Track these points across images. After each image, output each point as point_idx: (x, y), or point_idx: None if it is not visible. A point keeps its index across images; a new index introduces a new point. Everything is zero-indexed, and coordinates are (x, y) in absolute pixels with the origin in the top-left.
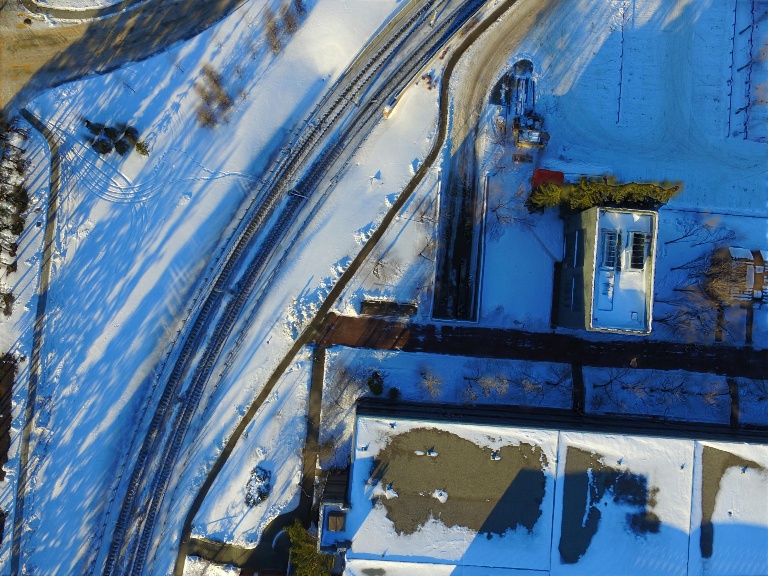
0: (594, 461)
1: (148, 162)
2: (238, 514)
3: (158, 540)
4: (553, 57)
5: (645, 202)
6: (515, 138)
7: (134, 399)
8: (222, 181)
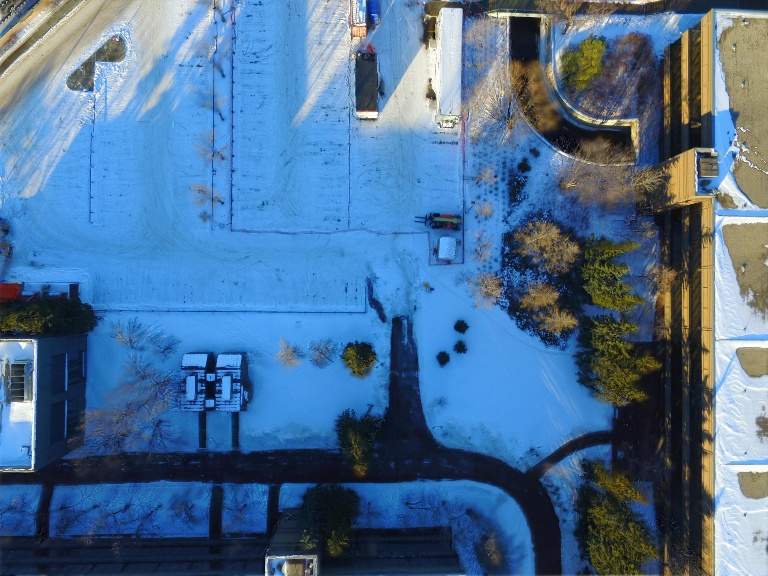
0: None
1: None
2: None
3: None
4: (18, 157)
5: (18, 331)
6: None
7: None
8: None
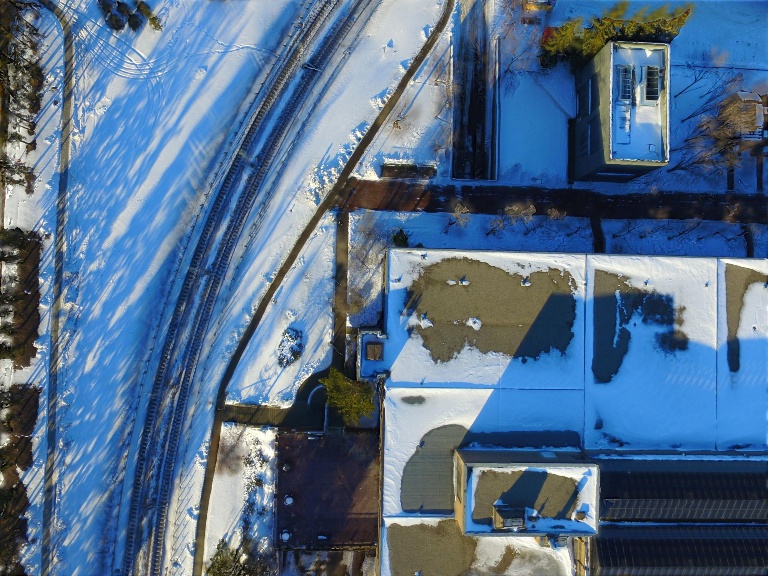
0: (621, 283)
1: (162, 37)
2: (272, 376)
3: (193, 409)
4: None
5: (657, 34)
6: (523, 1)
7: (161, 272)
8: (236, 54)
